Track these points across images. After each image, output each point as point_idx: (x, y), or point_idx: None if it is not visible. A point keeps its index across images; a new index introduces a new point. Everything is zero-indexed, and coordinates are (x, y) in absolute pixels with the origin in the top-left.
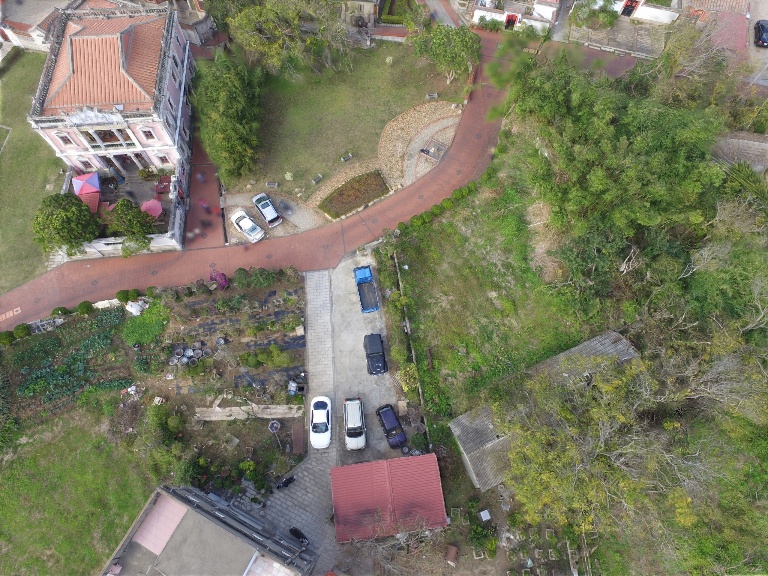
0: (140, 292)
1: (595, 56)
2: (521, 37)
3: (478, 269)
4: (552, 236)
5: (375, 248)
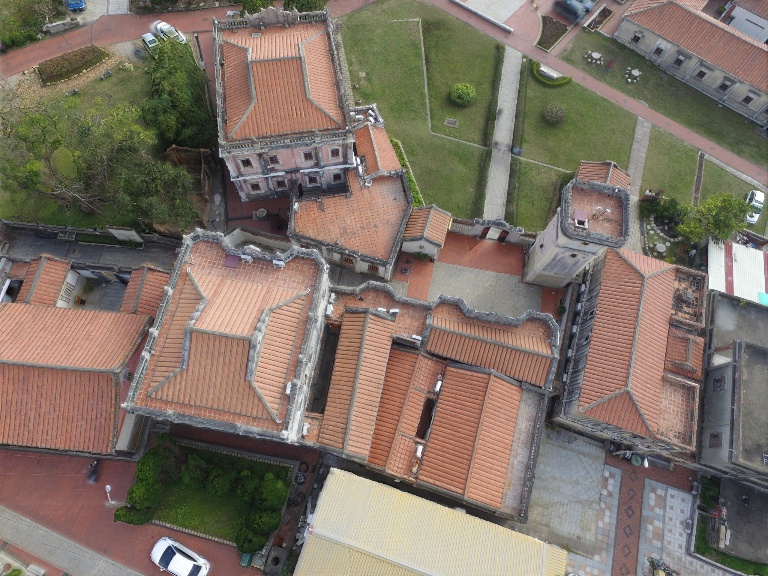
0: None
1: None
2: None
3: None
4: None
5: None
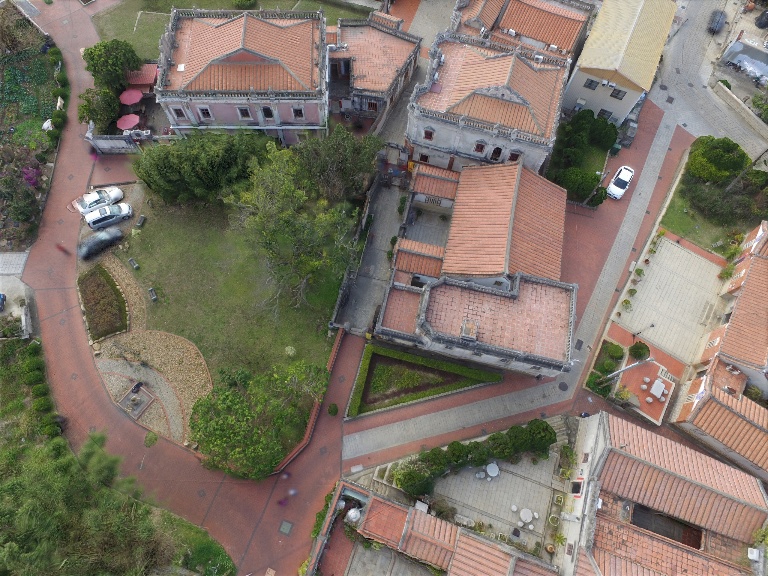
0: (65, 128)
1: None
2: None
3: None
4: None
5: None
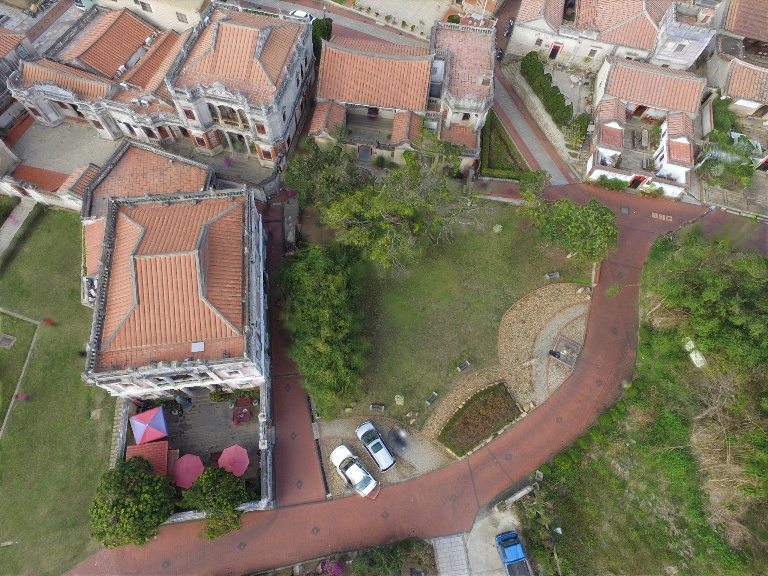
0: None
1: (735, 224)
2: (646, 198)
3: (647, 531)
4: (742, 496)
5: (516, 501)
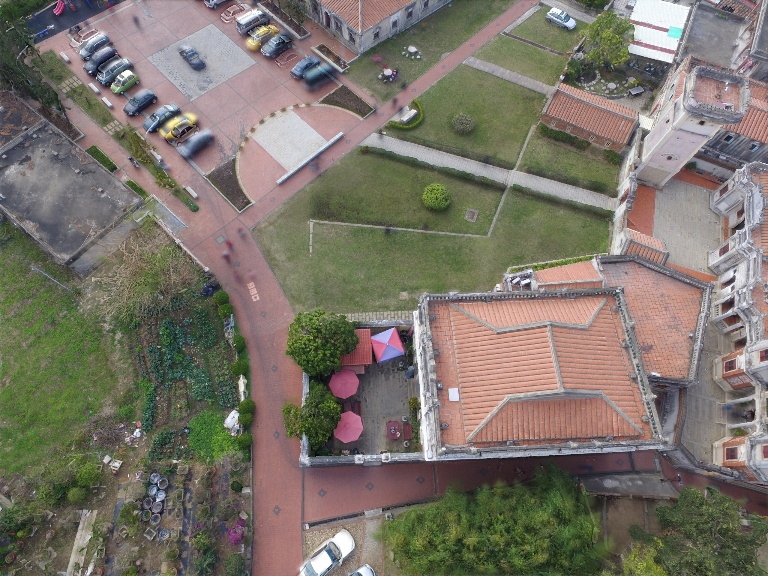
0: (254, 422)
1: None
2: None
3: None
4: None
5: None
